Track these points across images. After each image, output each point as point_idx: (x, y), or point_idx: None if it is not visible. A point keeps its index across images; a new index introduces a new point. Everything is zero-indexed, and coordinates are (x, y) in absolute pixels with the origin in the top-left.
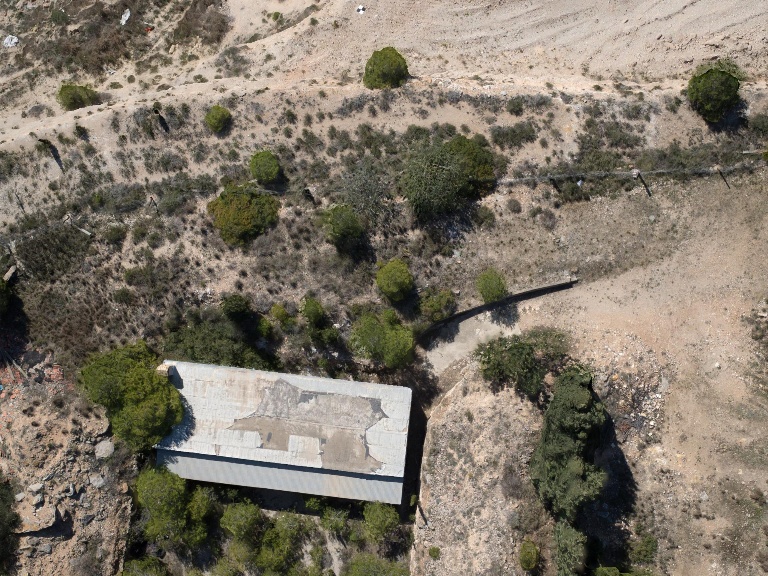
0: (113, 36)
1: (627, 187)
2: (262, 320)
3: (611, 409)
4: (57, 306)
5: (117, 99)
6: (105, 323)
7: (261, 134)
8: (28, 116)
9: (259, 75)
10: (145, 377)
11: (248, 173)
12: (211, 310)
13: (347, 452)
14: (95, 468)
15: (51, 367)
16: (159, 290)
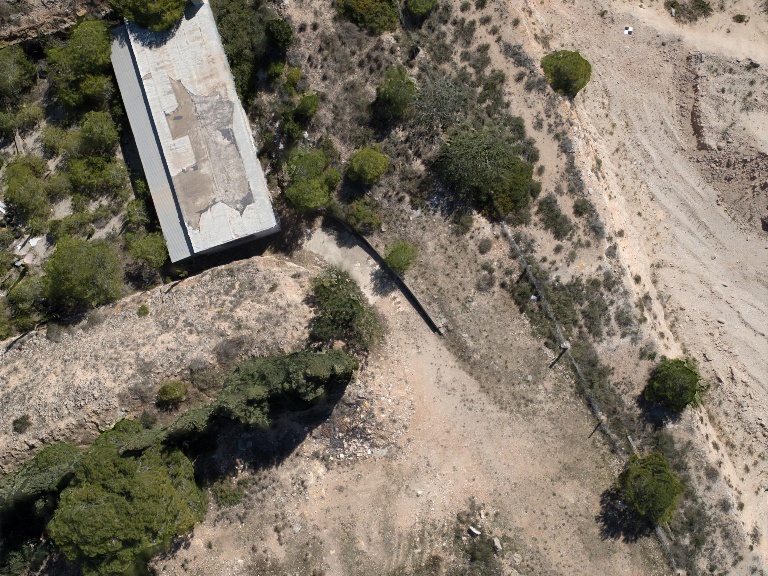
0: None
1: (548, 342)
2: (281, 64)
3: (337, 413)
4: None
5: None
6: None
7: None
8: None
9: None
10: None
11: None
12: (269, 13)
13: (195, 193)
14: None
15: None
16: None
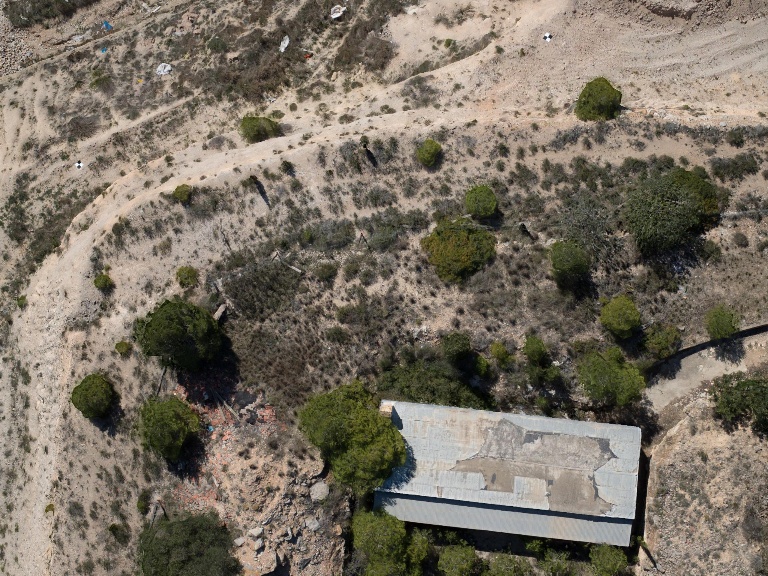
0: (273, 64)
1: None
2: (479, 358)
3: None
4: (267, 345)
5: (299, 130)
6: (318, 362)
7: (473, 168)
8: (209, 148)
9: (449, 105)
10: (370, 419)
11: (461, 208)
12: (427, 348)
13: (575, 493)
14: (310, 511)
15: (263, 408)
16: (373, 328)
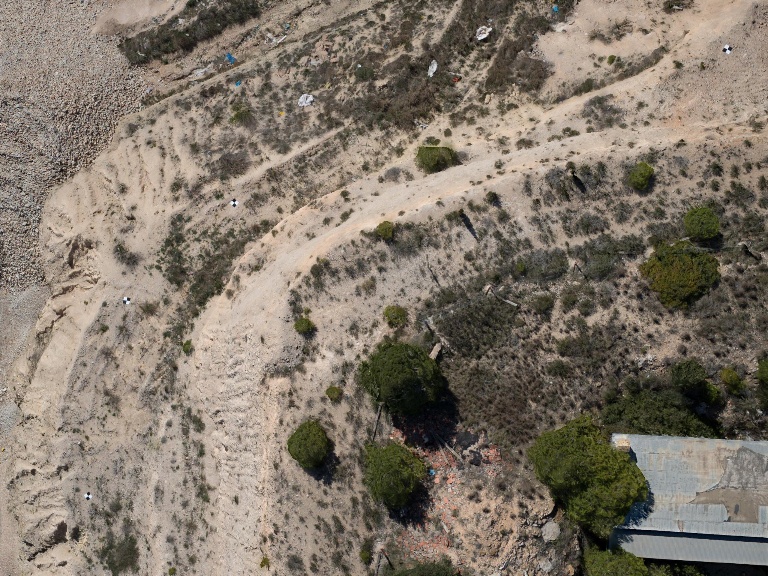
0: (424, 89)
1: None
2: (708, 385)
3: None
4: (486, 383)
5: (476, 157)
6: (540, 398)
7: (686, 189)
8: (385, 181)
9: (635, 124)
10: (609, 455)
11: (678, 231)
12: (654, 378)
13: None
14: (542, 552)
15: (487, 448)
16: (597, 360)
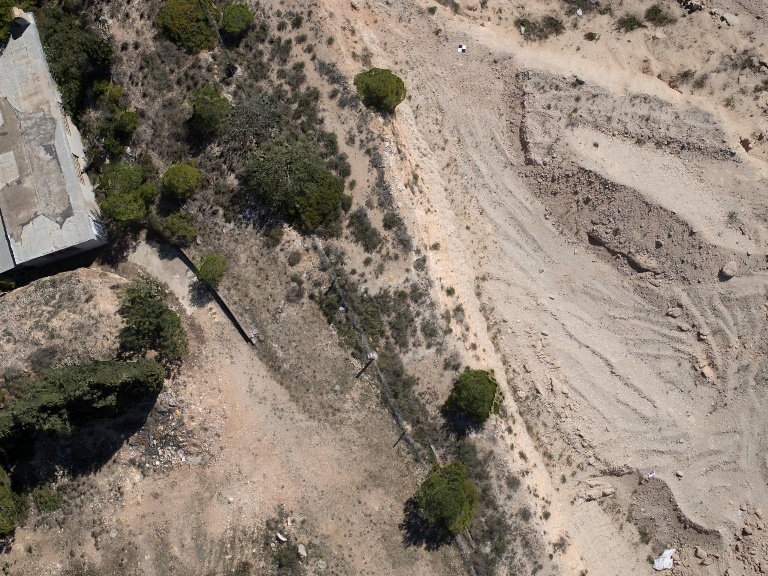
0: None
1: (354, 353)
2: (105, 82)
3: (151, 421)
4: None
5: None
6: None
7: (270, 3)
8: None
9: None
10: (1, 0)
11: None
12: (94, 33)
13: (18, 207)
14: None
15: None
16: None
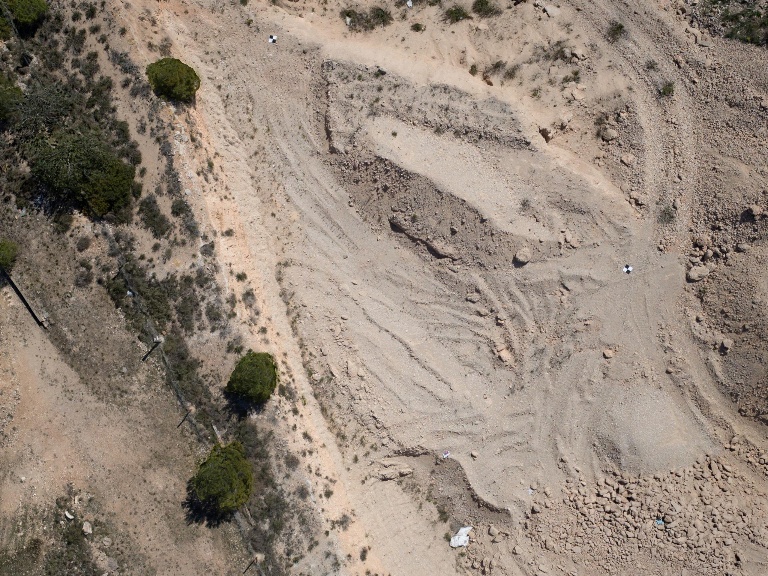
0: None
1: (140, 336)
2: None
3: None
4: None
5: None
6: None
7: None
8: None
9: None
10: None
11: None
12: None
13: None
14: None
15: None
16: None
